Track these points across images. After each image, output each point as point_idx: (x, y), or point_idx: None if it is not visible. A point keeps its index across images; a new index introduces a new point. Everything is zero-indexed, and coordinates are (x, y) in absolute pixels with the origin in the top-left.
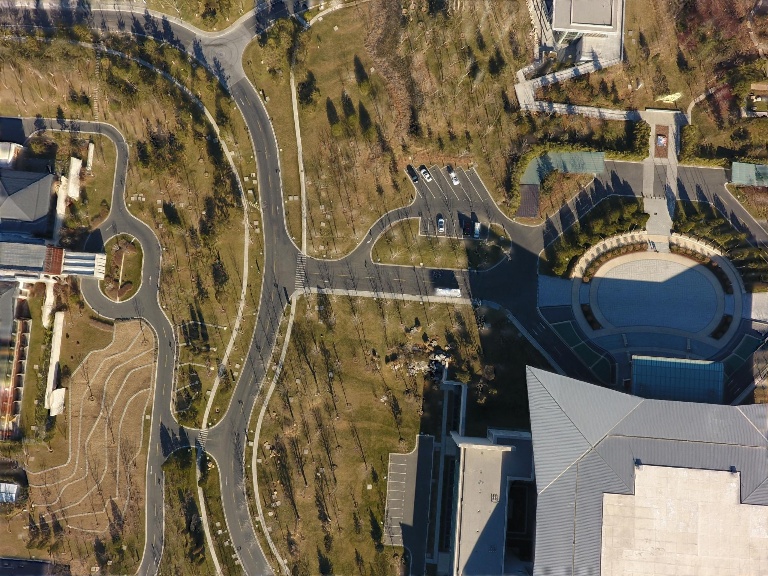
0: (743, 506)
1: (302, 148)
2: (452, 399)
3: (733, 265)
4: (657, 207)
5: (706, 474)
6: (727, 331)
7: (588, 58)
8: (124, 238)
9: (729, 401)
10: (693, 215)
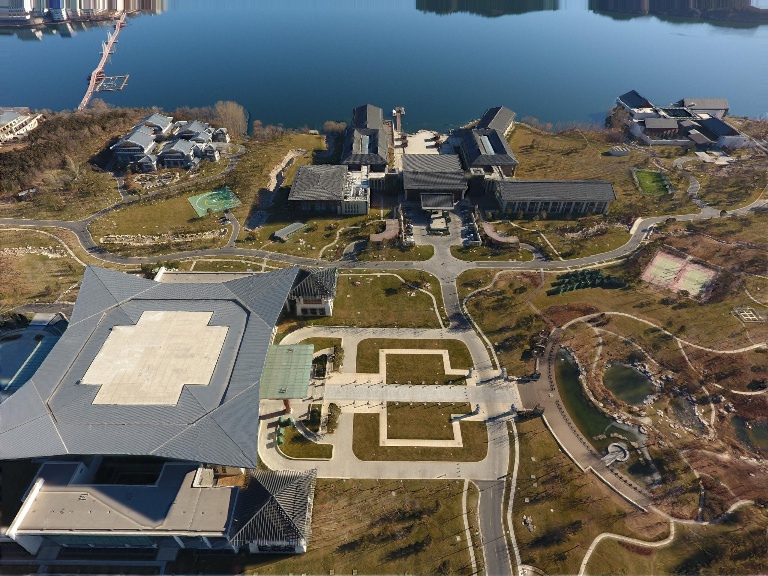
0: (138, 324)
1: None
2: None
3: None
4: None
5: (107, 343)
6: None
7: None
8: None
9: None
10: None
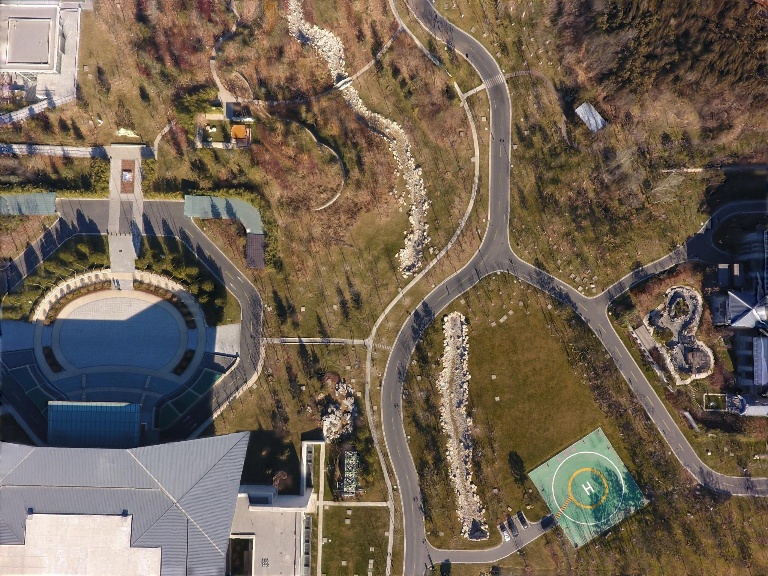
0: (133, 549)
1: None
2: None
3: None
4: (122, 244)
5: (97, 519)
6: (188, 366)
7: (43, 96)
8: None
9: (184, 437)
10: None
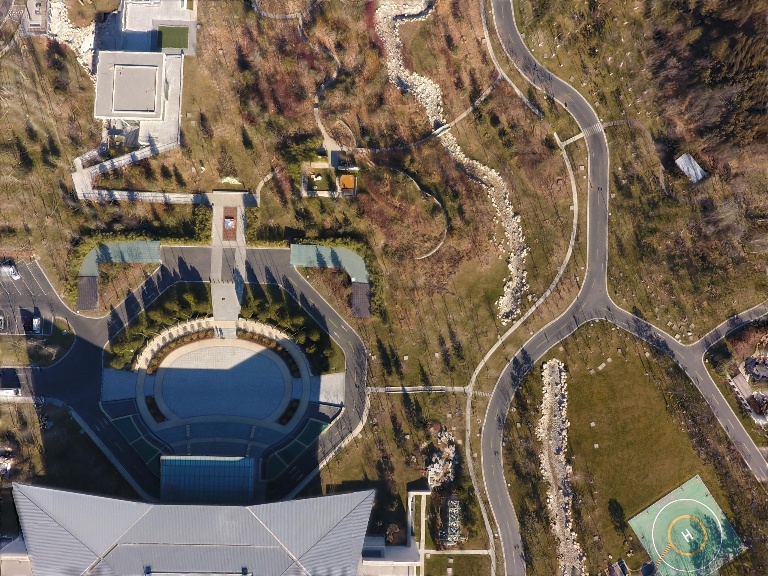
0: None
1: None
2: None
3: (299, 348)
4: (225, 292)
5: None
6: (293, 416)
7: (146, 143)
8: None
9: (290, 489)
10: None
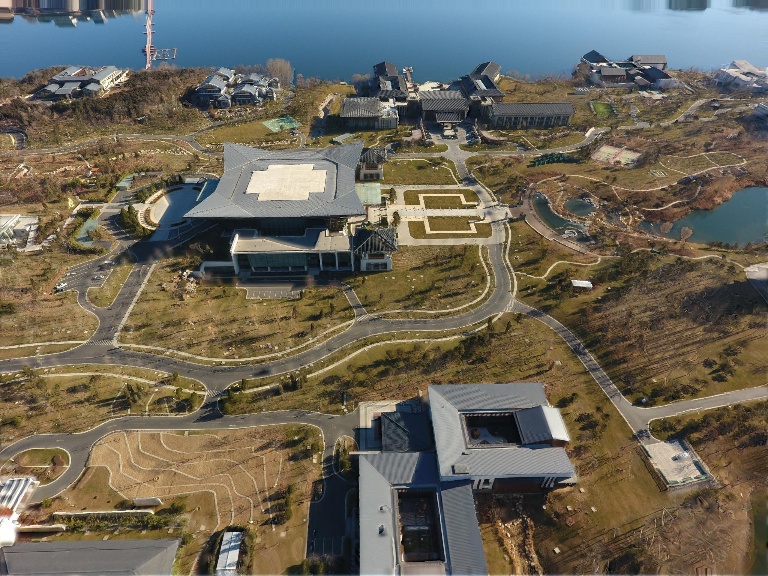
0: (268, 170)
1: (0, 347)
2: (216, 275)
3: (169, 187)
4: None
5: None
6: (200, 188)
7: (28, 227)
8: (6, 468)
9: None
10: (137, 196)
